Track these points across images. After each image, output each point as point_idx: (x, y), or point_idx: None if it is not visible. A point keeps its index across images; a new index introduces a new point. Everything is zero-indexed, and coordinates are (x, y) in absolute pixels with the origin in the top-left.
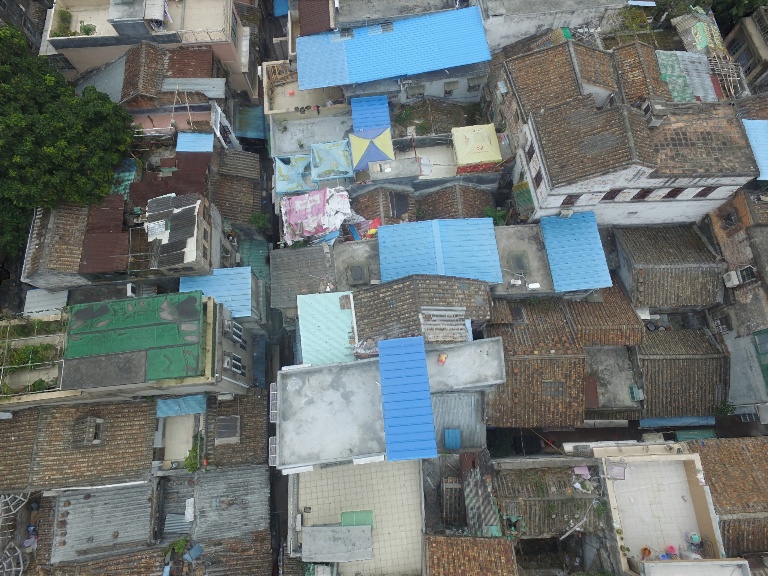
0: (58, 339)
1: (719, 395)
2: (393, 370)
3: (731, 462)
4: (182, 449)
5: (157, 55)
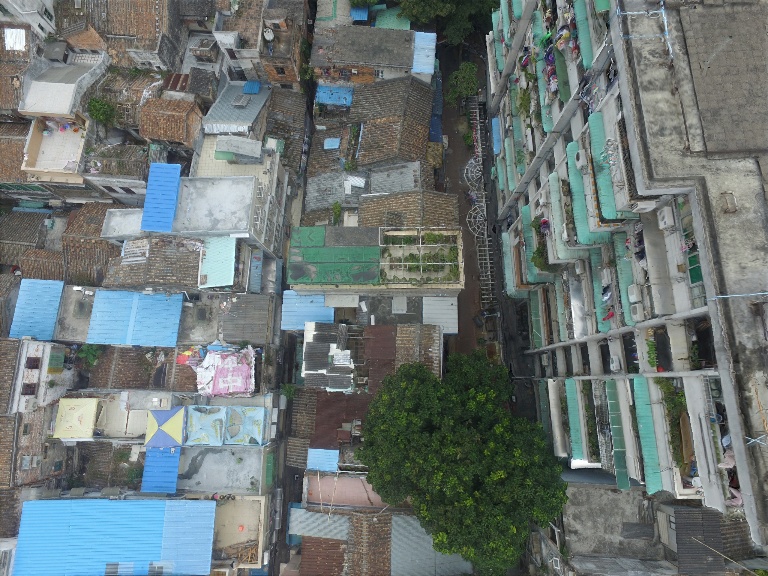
0: (407, 276)
1: (0, 220)
2: (165, 213)
3: (7, 167)
4: (352, 222)
5: (353, 573)
